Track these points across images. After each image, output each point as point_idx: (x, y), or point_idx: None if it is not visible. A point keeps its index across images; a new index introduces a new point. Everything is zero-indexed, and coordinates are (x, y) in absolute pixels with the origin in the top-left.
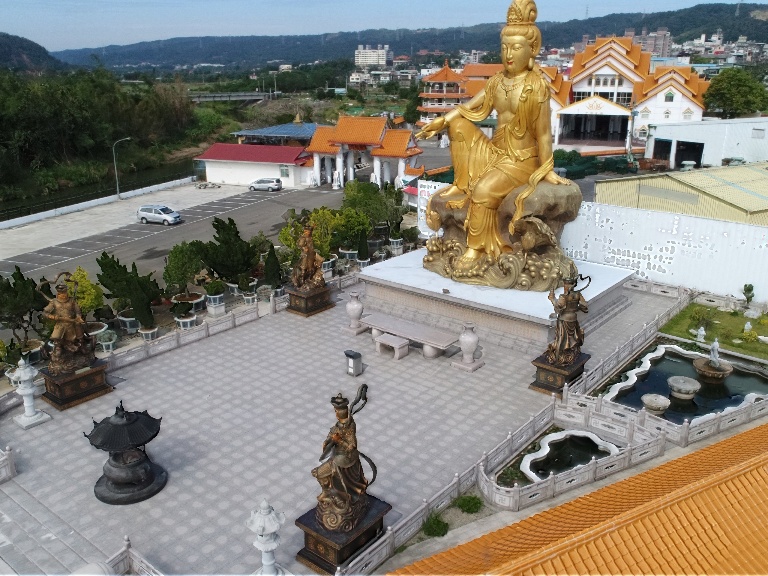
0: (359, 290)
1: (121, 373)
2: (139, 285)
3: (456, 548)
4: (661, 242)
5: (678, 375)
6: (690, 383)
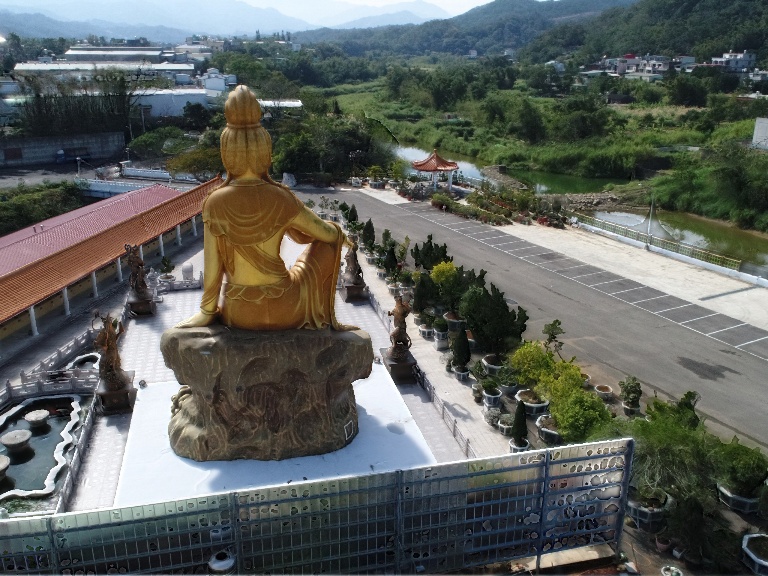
0: (419, 410)
1: (366, 306)
2: (422, 283)
3: (77, 278)
4: (92, 559)
5: (28, 483)
6: (11, 437)
